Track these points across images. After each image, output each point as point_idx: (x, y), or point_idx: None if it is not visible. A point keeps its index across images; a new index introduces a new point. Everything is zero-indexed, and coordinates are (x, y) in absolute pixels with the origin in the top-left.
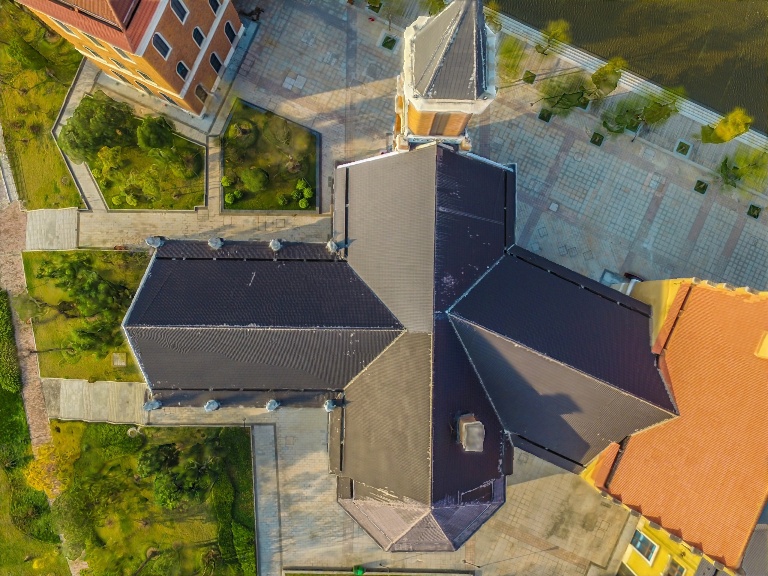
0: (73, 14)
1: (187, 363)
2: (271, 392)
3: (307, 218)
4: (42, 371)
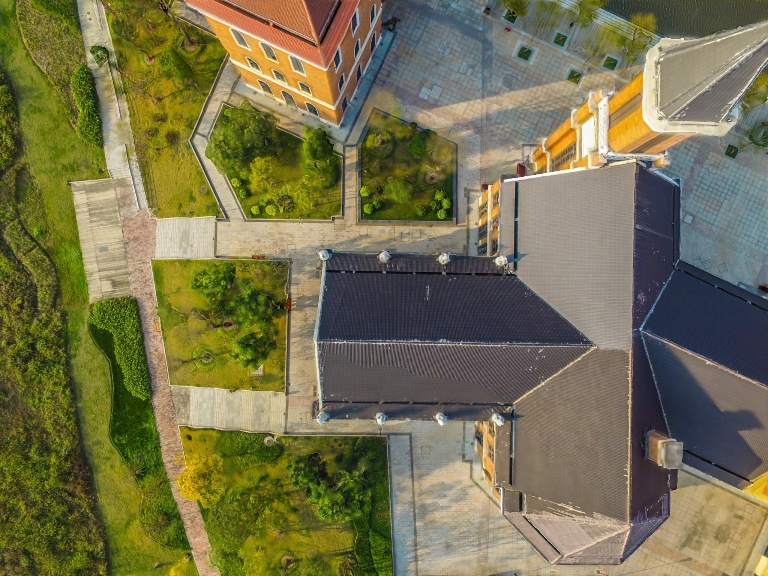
0: (267, 28)
1: (368, 377)
2: (440, 405)
3: (443, 229)
4: (172, 379)
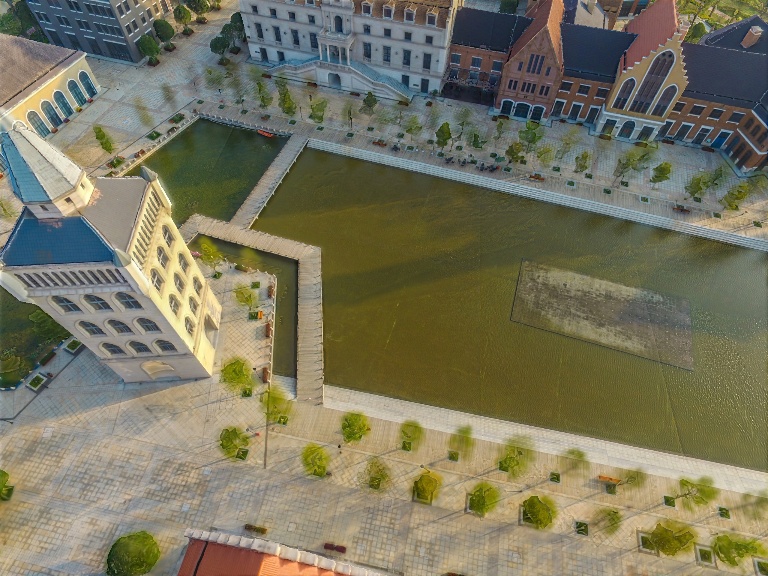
0: None
1: None
2: None
3: None
4: None
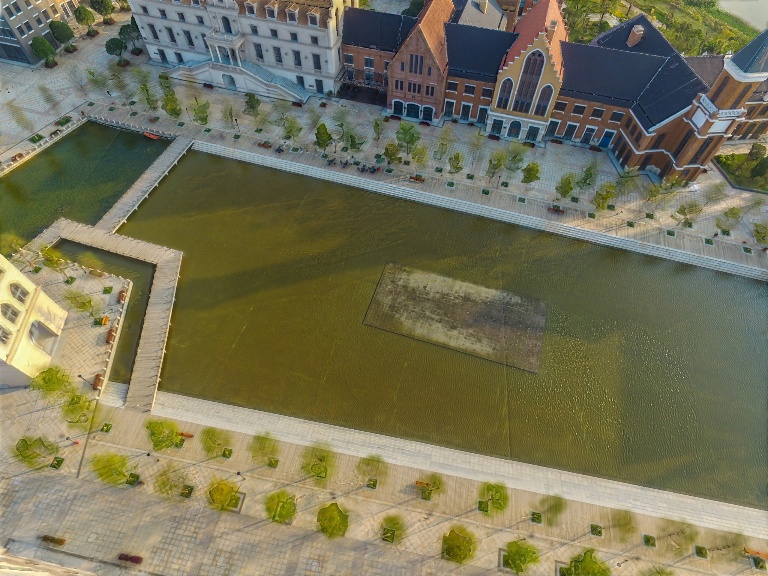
0: None
1: None
2: None
3: None
4: None
